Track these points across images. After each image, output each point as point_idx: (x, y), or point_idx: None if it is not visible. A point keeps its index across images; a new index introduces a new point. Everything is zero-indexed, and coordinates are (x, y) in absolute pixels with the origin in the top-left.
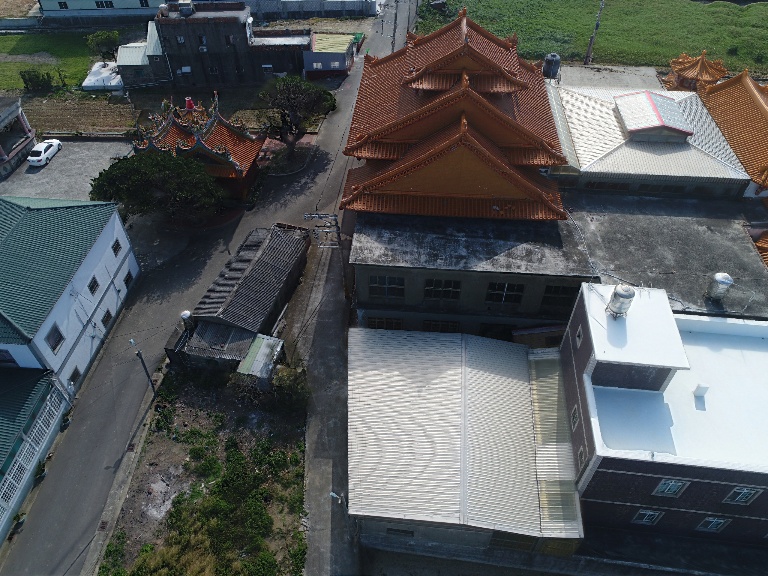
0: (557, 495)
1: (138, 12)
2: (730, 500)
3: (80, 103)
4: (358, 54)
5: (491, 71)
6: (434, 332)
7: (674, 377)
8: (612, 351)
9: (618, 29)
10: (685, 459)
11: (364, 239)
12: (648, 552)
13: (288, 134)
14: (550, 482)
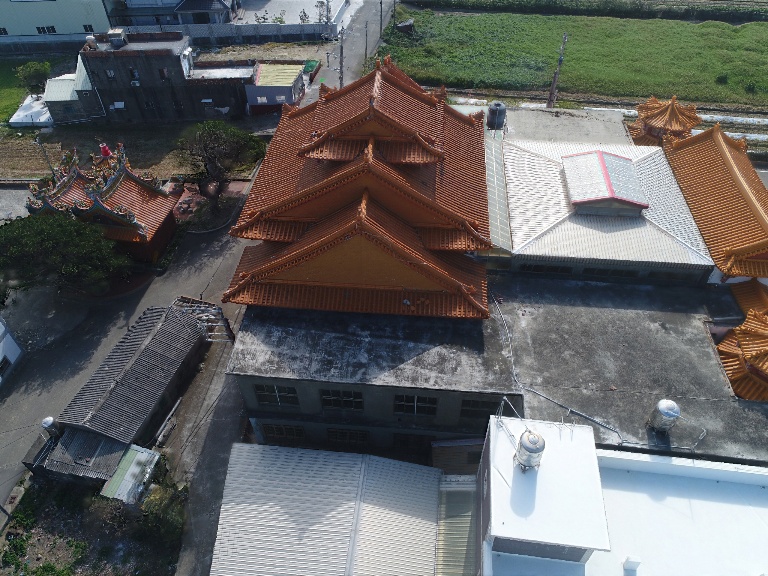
0: None
1: (83, 37)
2: None
3: (4, 142)
4: (311, 84)
5: (404, 137)
6: (331, 451)
7: None
8: (513, 522)
9: (597, 54)
10: None
11: (249, 339)
12: None
13: (209, 186)
14: None
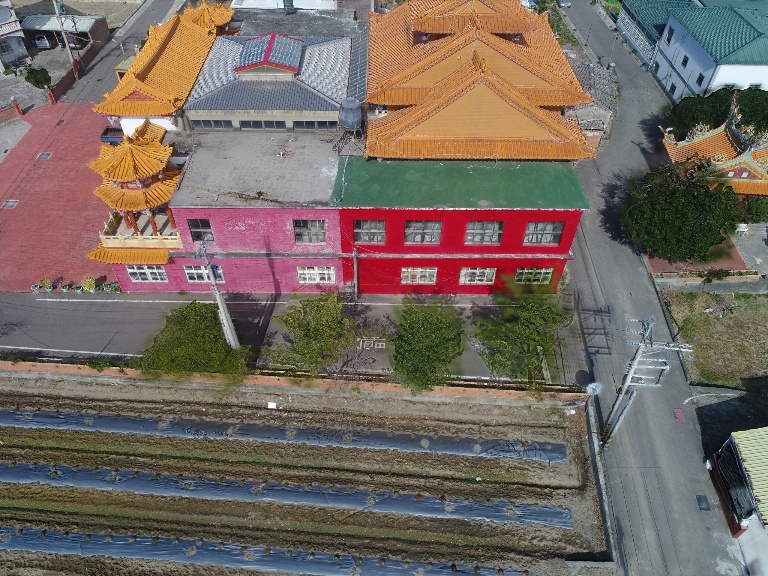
0: None
1: None
2: None
3: None
4: None
5: None
6: None
7: (327, 4)
8: None
9: None
10: None
11: None
12: None
13: None
14: None
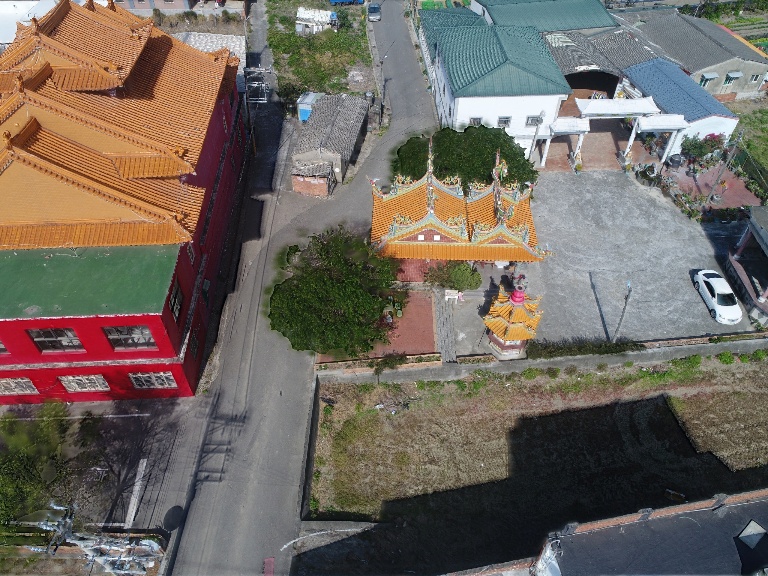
0: None
1: None
2: None
3: None
4: None
5: None
6: None
7: None
8: None
9: None
10: None
11: None
12: None
13: None
14: None
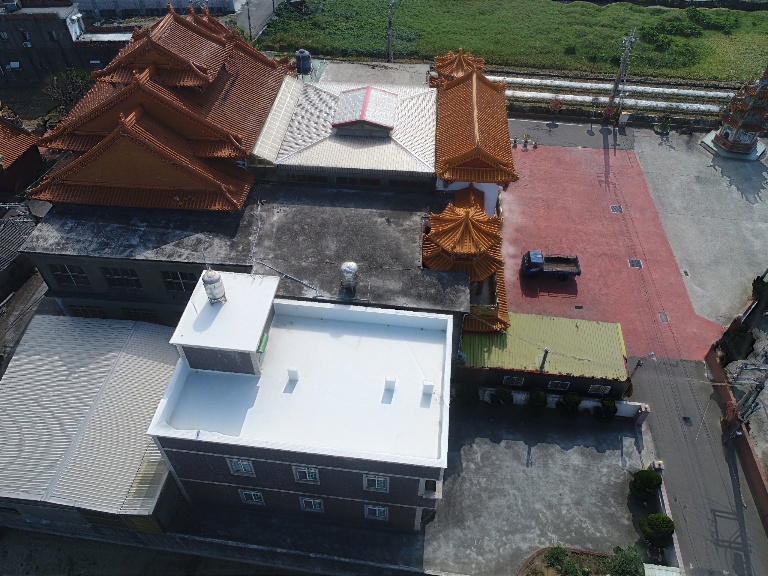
0: (150, 474)
1: None
2: (303, 480)
3: None
4: None
5: (180, 65)
6: (111, 319)
7: (280, 362)
8: (190, 335)
9: (466, 28)
10: (228, 438)
11: (46, 228)
12: (259, 531)
13: None
14: (151, 462)
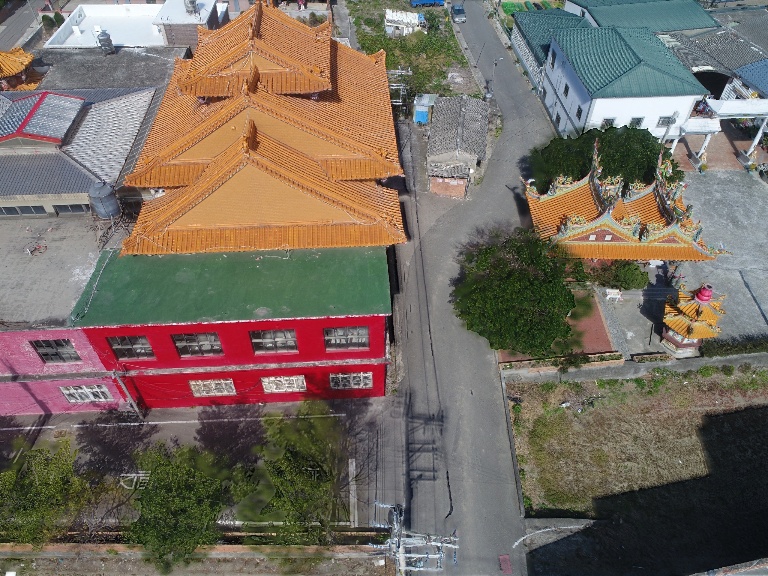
0: None
1: None
2: None
3: None
4: None
5: None
6: None
7: None
8: (205, 2)
9: None
10: None
11: None
12: None
13: None
14: None
